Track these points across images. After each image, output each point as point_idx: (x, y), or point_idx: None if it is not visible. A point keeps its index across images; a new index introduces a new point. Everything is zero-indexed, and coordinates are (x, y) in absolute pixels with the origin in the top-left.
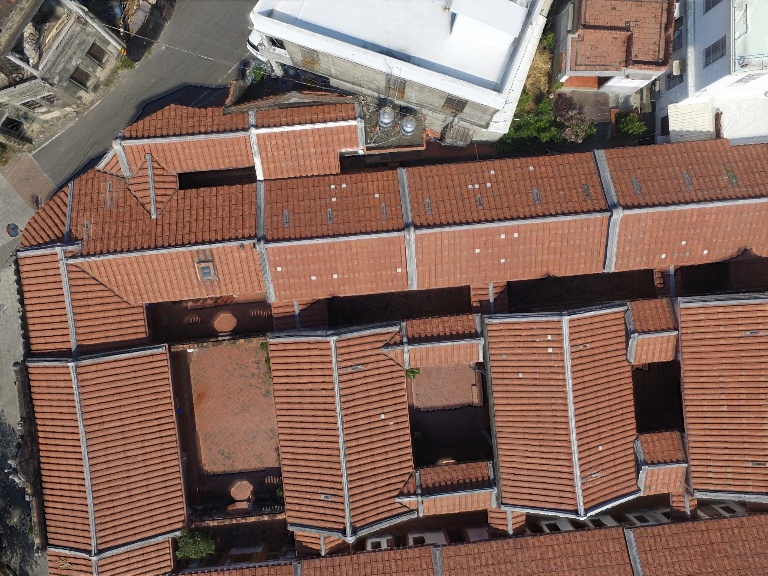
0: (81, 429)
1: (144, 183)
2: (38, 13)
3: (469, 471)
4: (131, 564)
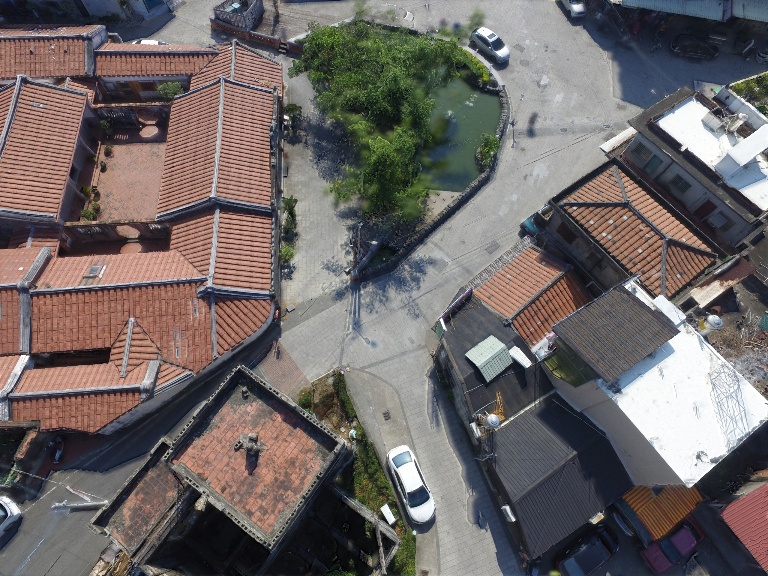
0: (216, 154)
1: (138, 352)
2: (184, 520)
3: None
4: (213, 79)
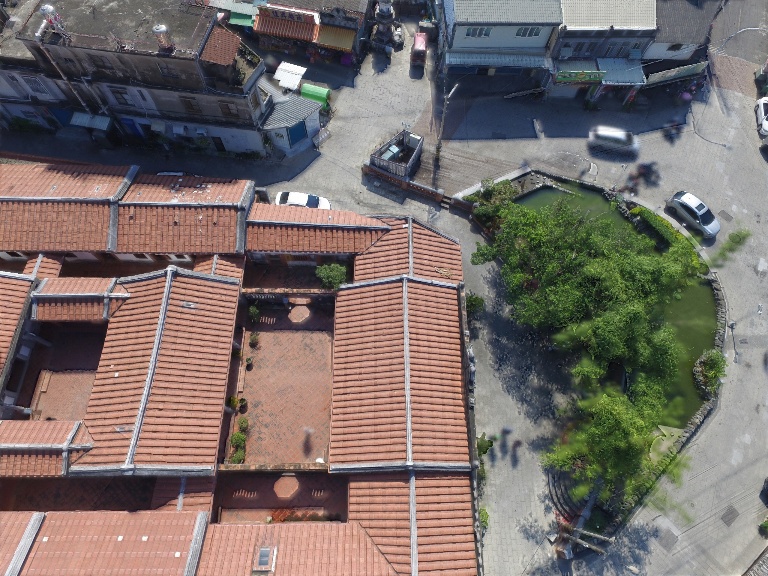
0: (407, 393)
1: None
2: None
3: (56, 313)
4: (385, 266)
